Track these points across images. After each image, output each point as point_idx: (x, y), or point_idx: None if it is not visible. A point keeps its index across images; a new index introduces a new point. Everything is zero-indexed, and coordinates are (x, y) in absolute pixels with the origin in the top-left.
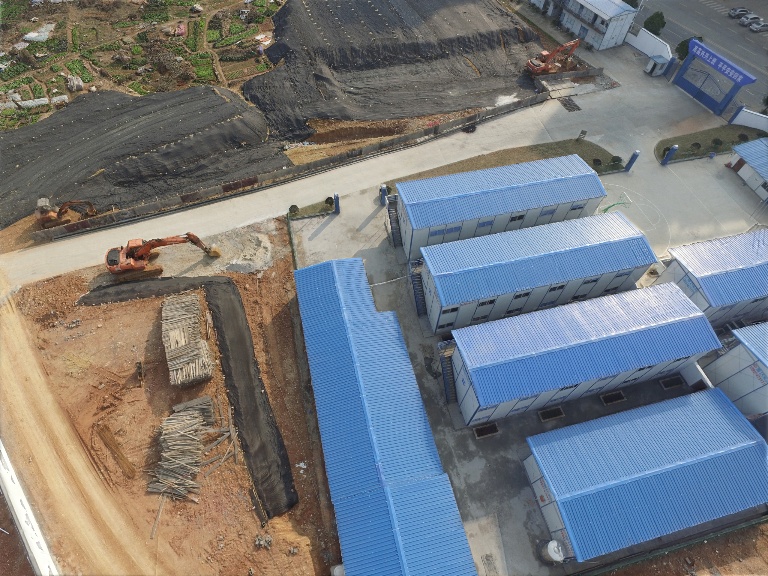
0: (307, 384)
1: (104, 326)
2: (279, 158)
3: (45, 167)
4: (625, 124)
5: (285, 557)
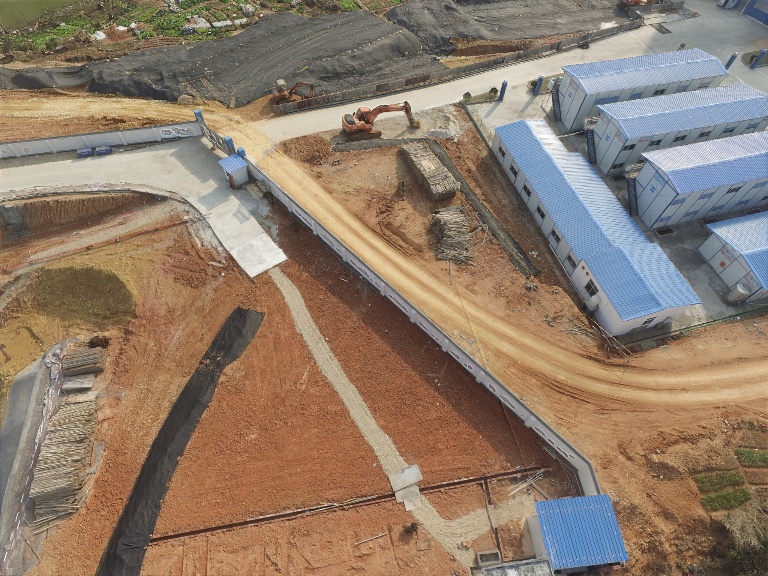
0: (519, 206)
1: (359, 164)
2: (437, 65)
3: (259, 65)
4: (711, 43)
5: (550, 295)
